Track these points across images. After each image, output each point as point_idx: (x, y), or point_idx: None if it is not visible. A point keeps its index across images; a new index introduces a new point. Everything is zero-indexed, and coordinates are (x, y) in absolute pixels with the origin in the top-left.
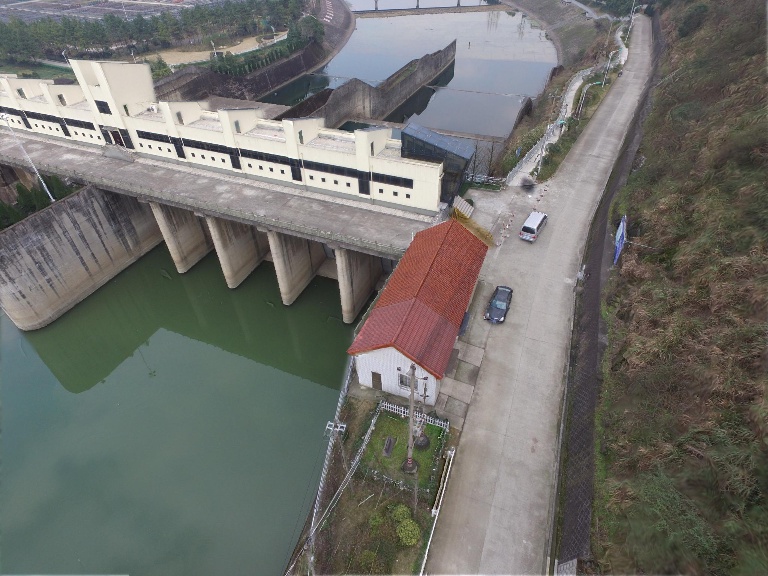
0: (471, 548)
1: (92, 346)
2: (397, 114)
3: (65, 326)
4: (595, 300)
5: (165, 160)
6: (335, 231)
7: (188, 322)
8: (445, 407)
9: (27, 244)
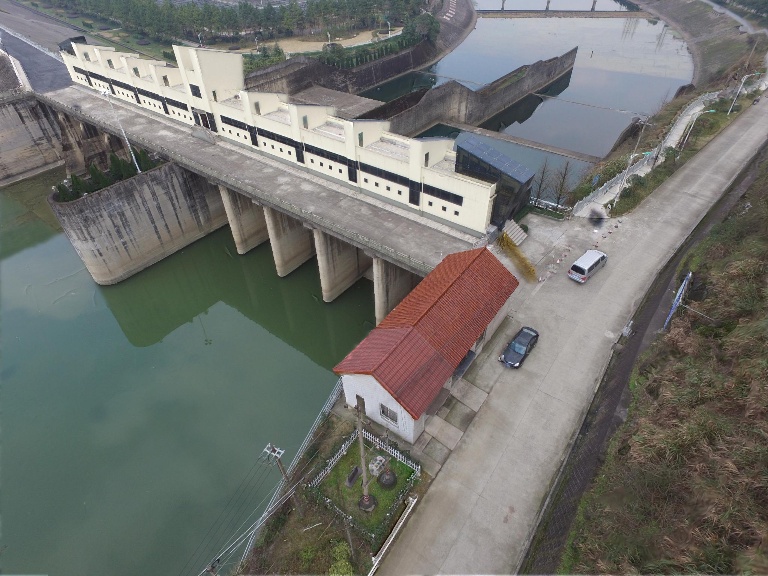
0: None
1: (155, 307)
2: (496, 120)
3: (133, 286)
4: (628, 365)
5: (242, 146)
6: (375, 238)
7: (243, 300)
8: (425, 448)
9: (109, 208)
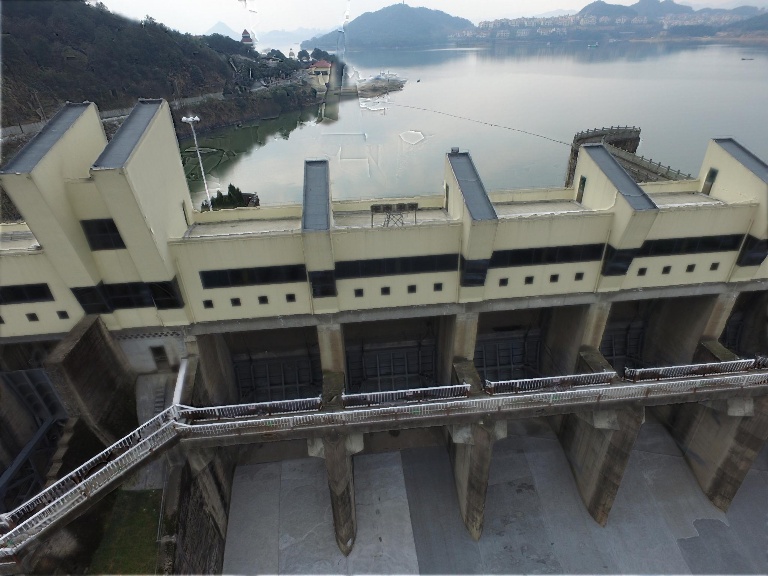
0: None
1: None
2: None
3: None
4: None
5: None
6: None
7: None
8: None
9: None
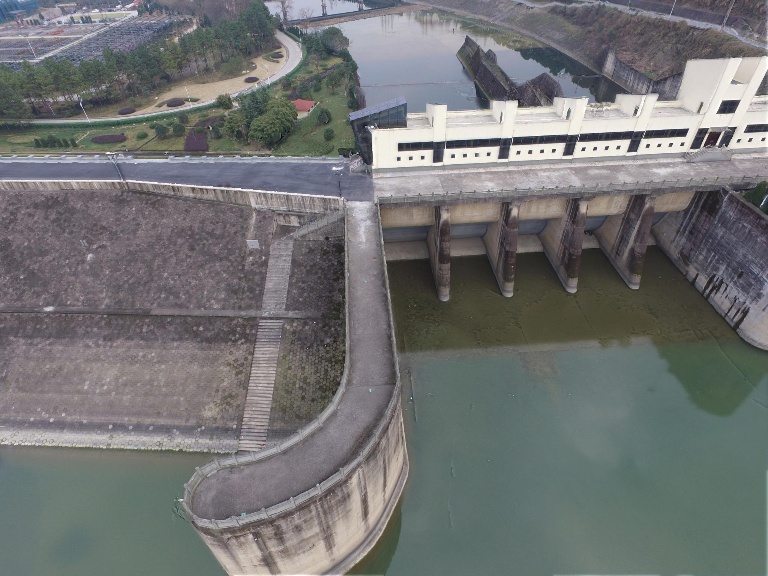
0: None
1: None
2: None
3: None
4: None
5: (757, 151)
6: None
7: None
8: None
9: None
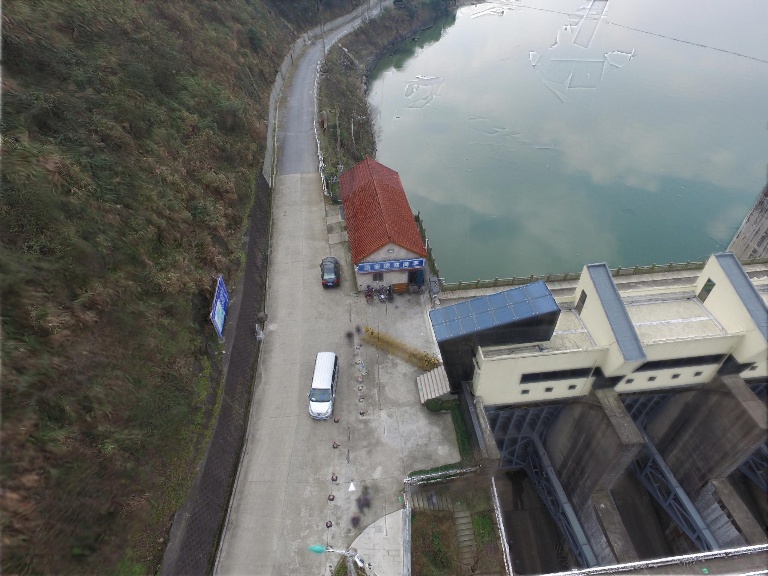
0: (305, 180)
1: None
2: None
3: None
4: None
5: None
6: None
7: None
8: None
9: None
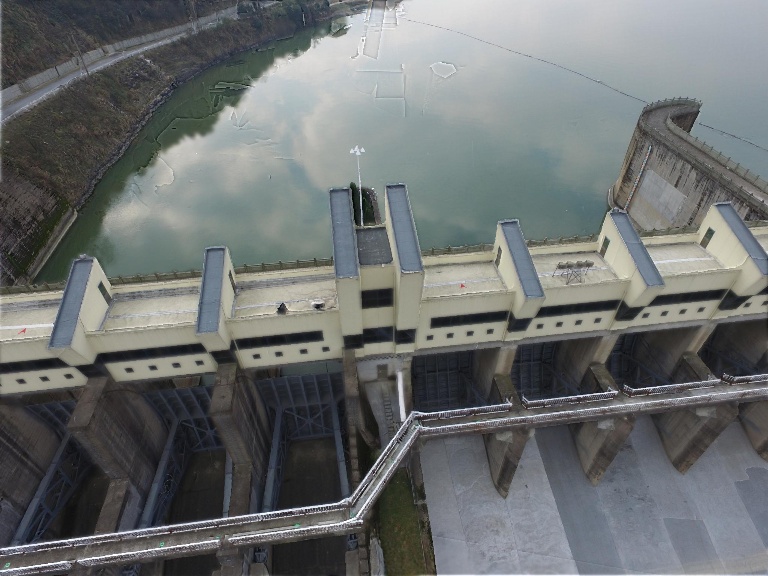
0: None
1: None
2: None
3: None
4: None
5: None
6: None
7: None
8: None
9: None
